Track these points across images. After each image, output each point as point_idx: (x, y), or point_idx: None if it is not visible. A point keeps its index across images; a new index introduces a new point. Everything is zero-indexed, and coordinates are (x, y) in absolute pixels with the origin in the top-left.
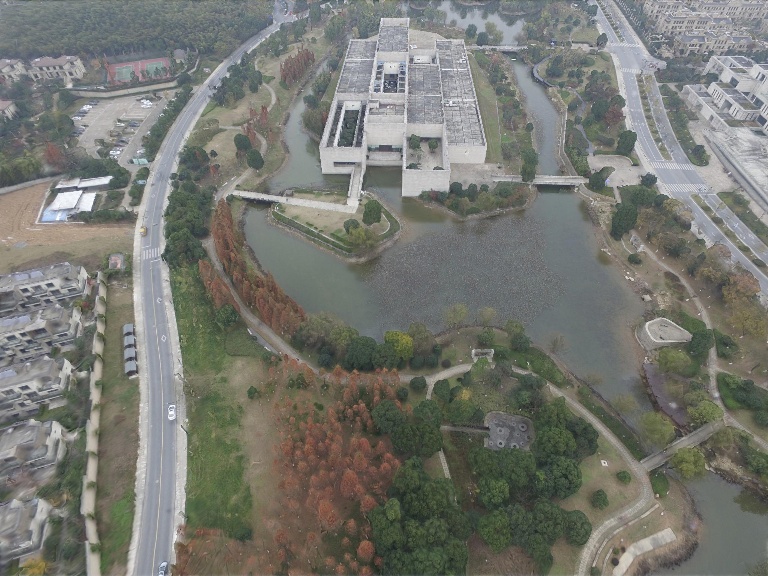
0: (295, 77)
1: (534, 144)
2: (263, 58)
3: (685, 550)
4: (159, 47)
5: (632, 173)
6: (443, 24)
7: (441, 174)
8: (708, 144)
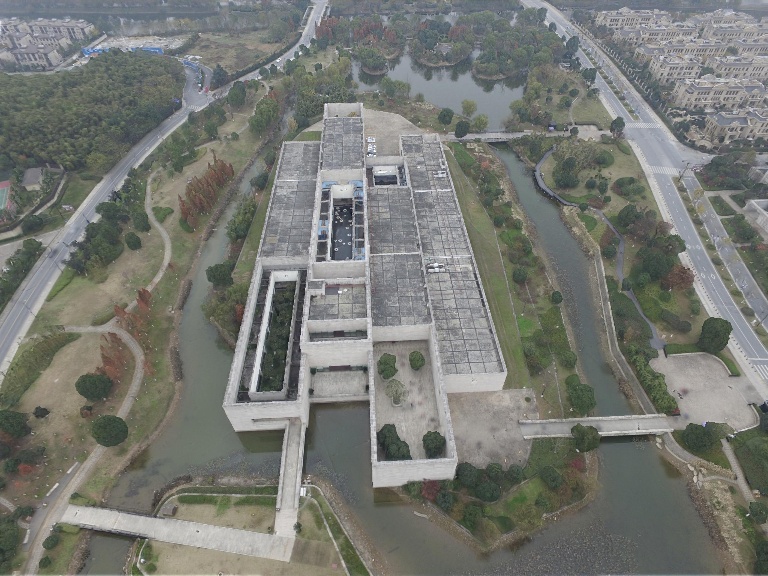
0: (203, 209)
1: (568, 329)
2: (160, 173)
3: None
4: (2, 166)
5: (736, 395)
6: (406, 98)
7: (441, 464)
8: None
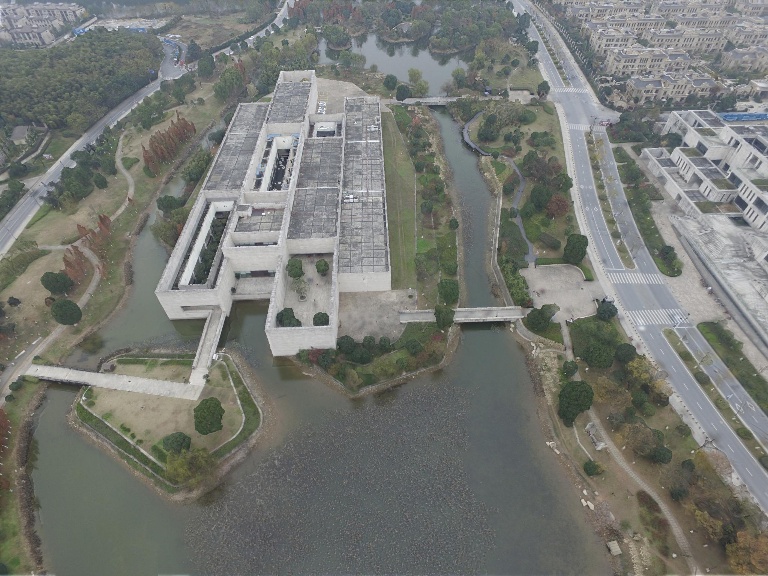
0: (165, 158)
1: (459, 249)
2: (131, 131)
3: None
4: None
5: (585, 294)
6: (362, 70)
7: (320, 331)
8: (678, 239)
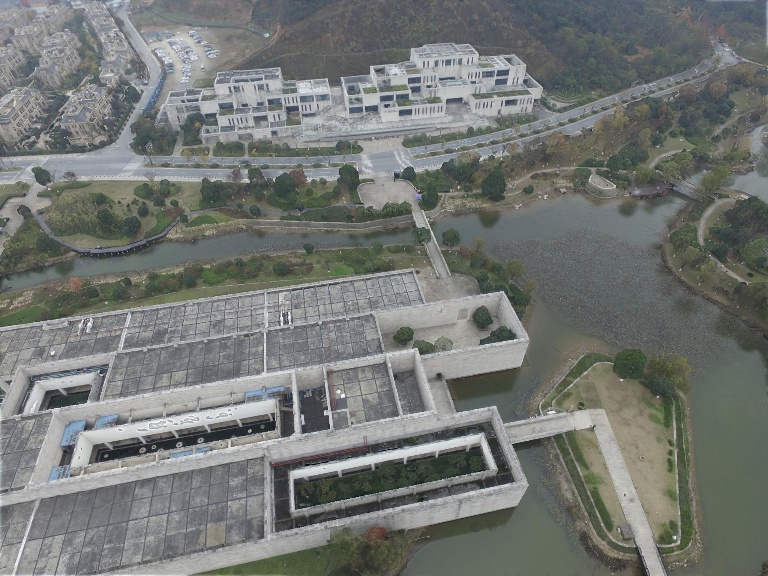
0: None
1: None
2: None
3: (744, 193)
4: None
5: (389, 184)
6: None
7: None
8: (322, 142)
